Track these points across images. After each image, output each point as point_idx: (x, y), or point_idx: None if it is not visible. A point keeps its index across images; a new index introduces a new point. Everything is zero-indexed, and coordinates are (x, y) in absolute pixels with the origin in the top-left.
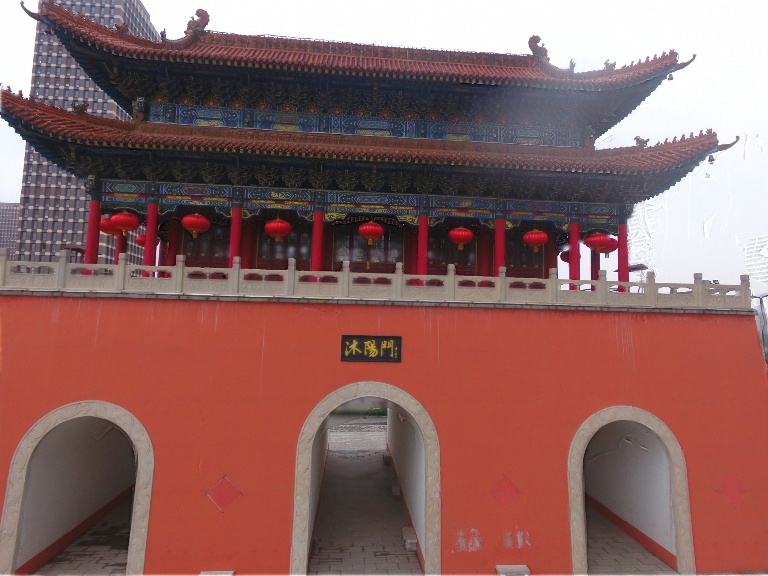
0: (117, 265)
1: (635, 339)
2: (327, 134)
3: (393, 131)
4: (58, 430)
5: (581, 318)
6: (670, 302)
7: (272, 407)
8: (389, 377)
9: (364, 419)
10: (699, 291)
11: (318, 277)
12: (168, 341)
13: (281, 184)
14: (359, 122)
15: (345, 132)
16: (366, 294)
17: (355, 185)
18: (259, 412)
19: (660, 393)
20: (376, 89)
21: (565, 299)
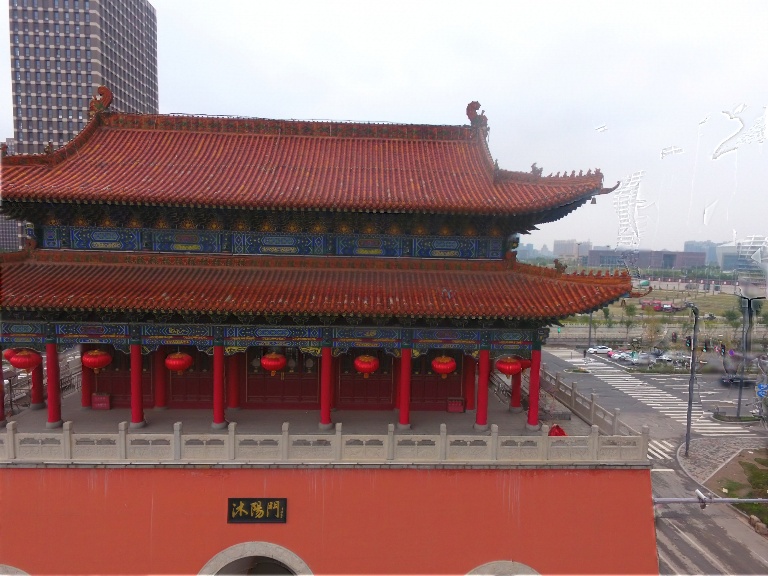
0: (6, 435)
1: (522, 495)
2: (228, 255)
3: (300, 247)
4: None
5: (468, 476)
6: (563, 455)
7: (163, 567)
8: (275, 537)
9: None
10: (594, 444)
11: (204, 440)
12: (61, 507)
13: (178, 319)
14: (263, 239)
15: (249, 250)
16: (253, 456)
17: (255, 317)
18: (151, 572)
19: (543, 547)
20: (274, 212)
21: (454, 456)
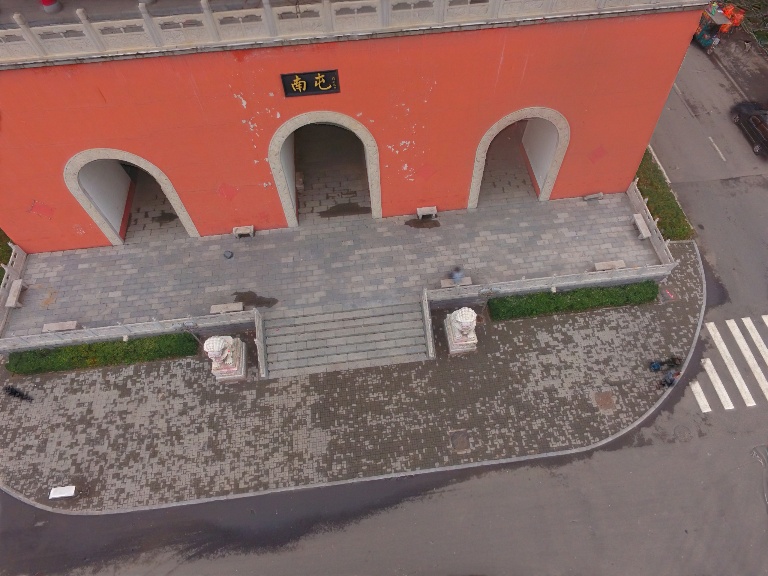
0: None
1: None
2: None
3: None
4: None
5: None
6: None
7: None
8: None
9: (339, 574)
10: None
11: None
12: None
13: None
14: None
15: None
16: None
17: None
18: None
19: None
20: None
21: None
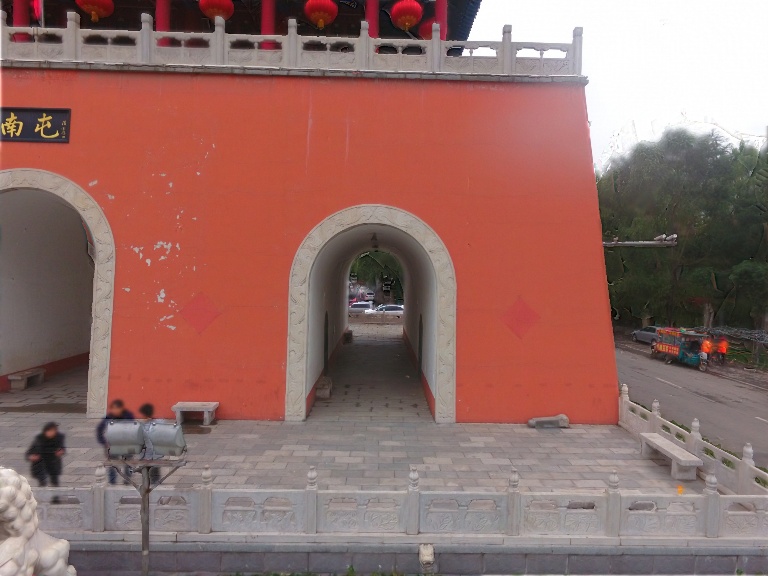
0: None
1: None
2: None
3: None
4: (393, 257)
5: None
6: None
7: None
8: None
9: None
10: None
11: None
12: None
13: None
14: None
15: None
16: None
17: None
18: None
19: None
20: None
21: None
